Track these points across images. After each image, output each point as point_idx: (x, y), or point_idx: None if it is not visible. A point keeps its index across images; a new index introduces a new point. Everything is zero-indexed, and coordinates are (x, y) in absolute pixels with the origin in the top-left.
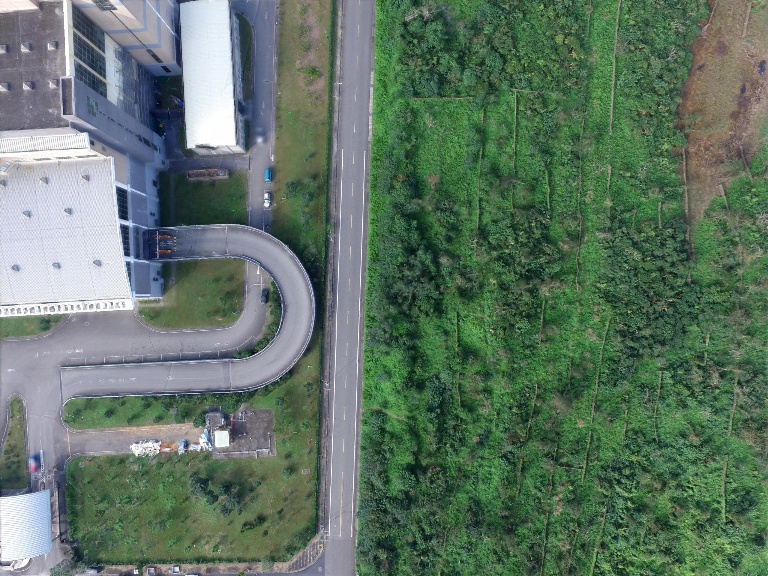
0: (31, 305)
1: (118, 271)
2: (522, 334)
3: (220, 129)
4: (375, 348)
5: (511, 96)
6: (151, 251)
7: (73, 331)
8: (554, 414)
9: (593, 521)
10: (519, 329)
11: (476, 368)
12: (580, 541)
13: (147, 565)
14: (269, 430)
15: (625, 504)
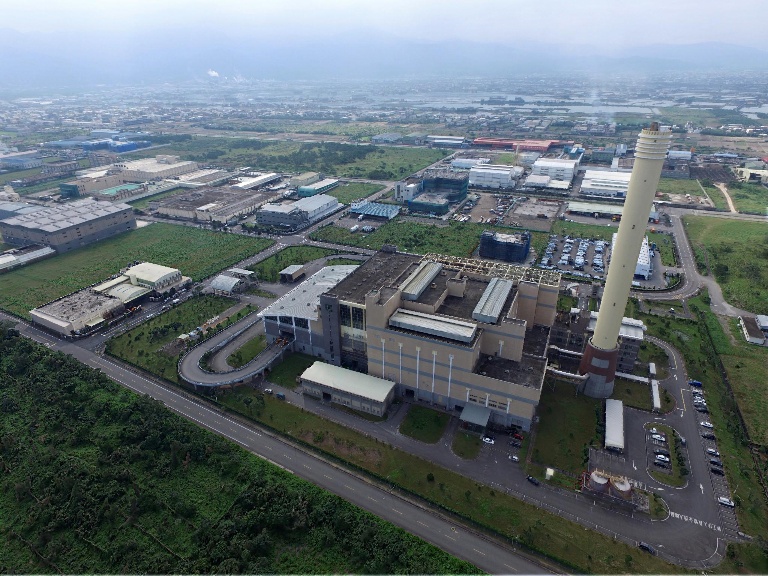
0: None
1: None
2: None
3: (313, 374)
4: None
5: (186, 556)
6: None
7: None
8: None
9: None
10: None
11: None
12: None
13: None
14: None
15: None
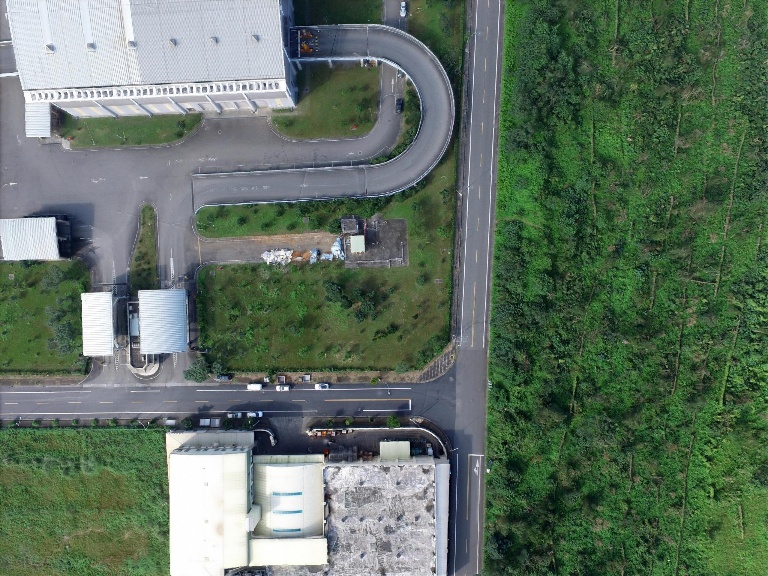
0: (184, 84)
1: (275, 47)
2: (660, 142)
3: None
4: (512, 156)
5: None
6: (292, 50)
7: (206, 139)
8: (690, 225)
9: (725, 335)
10: (657, 138)
11: (611, 179)
12: (712, 355)
13: (277, 373)
14: (402, 240)
15: (757, 319)
